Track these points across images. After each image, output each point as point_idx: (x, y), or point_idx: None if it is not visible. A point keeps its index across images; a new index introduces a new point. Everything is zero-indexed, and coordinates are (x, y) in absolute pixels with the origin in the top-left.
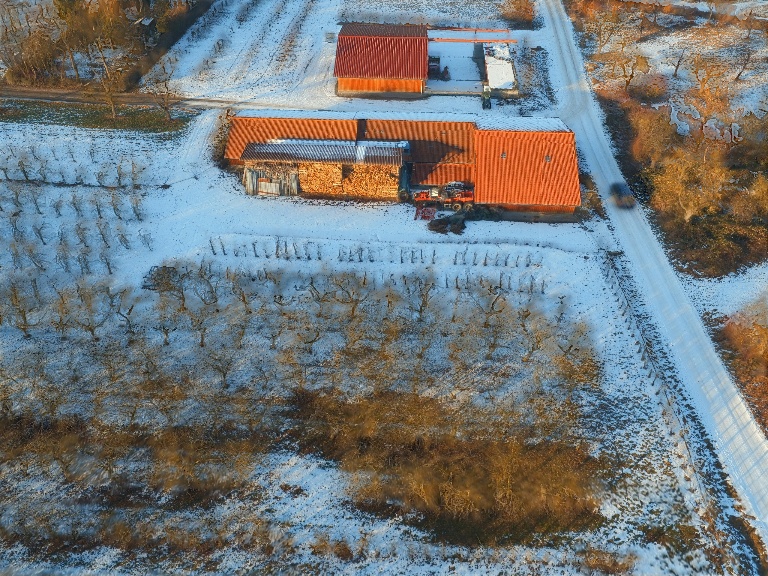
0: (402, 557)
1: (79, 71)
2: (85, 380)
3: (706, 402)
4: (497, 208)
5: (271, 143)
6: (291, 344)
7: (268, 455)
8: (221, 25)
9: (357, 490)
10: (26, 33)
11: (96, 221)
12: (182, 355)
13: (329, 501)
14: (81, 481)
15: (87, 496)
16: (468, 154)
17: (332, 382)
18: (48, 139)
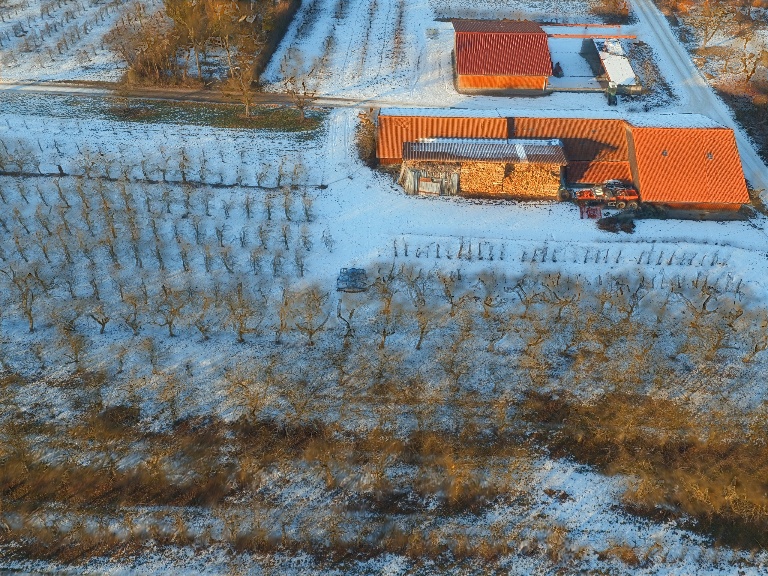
0: (689, 562)
1: (196, 70)
2: (314, 385)
3: None
4: (663, 206)
5: (422, 142)
6: (507, 346)
7: (522, 459)
8: (320, 22)
9: (622, 494)
10: (129, 32)
11: (266, 222)
12: (402, 358)
13: (598, 506)
14: (343, 487)
15: (354, 503)
16: (621, 152)
17: (561, 385)
18: (189, 139)
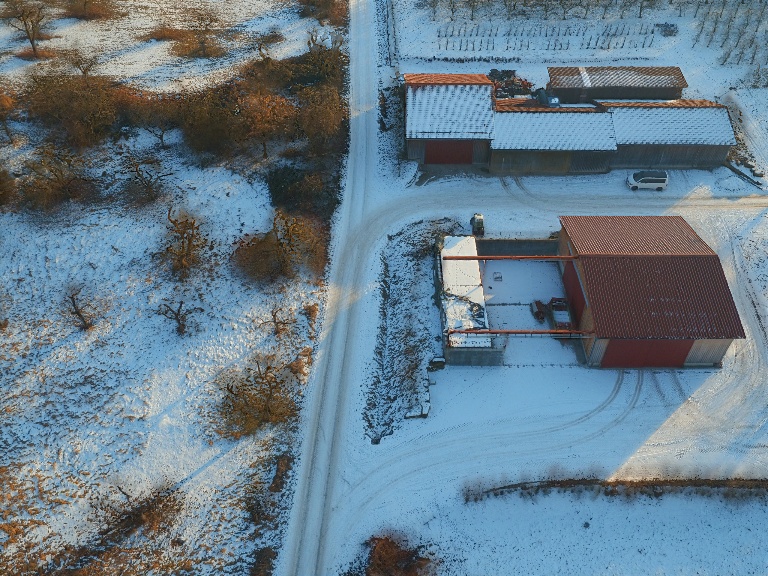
0: None
1: None
2: None
3: (368, 3)
4: None
5: None
6: None
7: None
8: None
9: None
10: None
11: None
12: (622, 0)
13: None
14: None
15: None
16: None
17: None
18: None
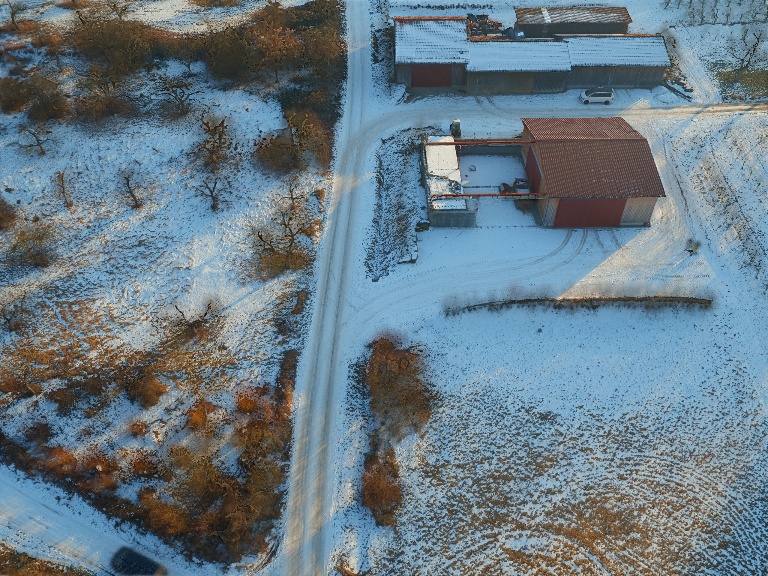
0: None
1: None
2: None
3: None
4: None
5: None
6: None
7: None
8: None
9: None
10: None
11: None
12: None
13: None
14: None
15: None
16: None
17: None
18: None
